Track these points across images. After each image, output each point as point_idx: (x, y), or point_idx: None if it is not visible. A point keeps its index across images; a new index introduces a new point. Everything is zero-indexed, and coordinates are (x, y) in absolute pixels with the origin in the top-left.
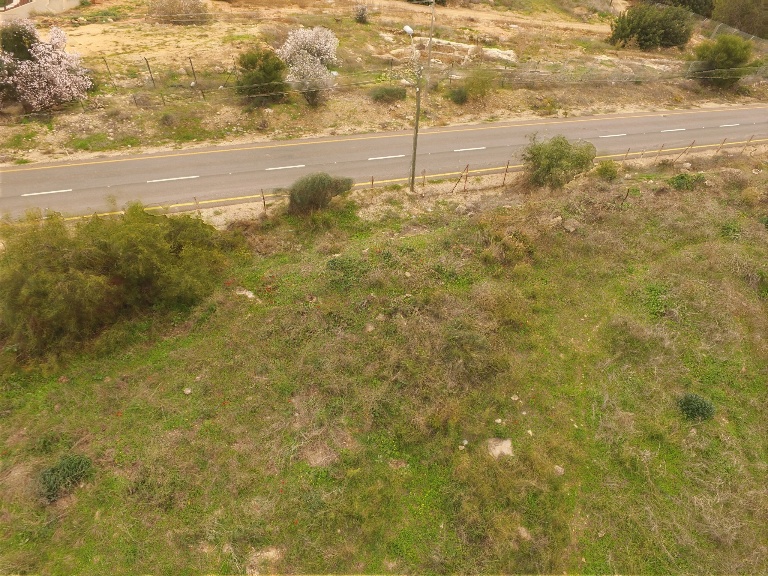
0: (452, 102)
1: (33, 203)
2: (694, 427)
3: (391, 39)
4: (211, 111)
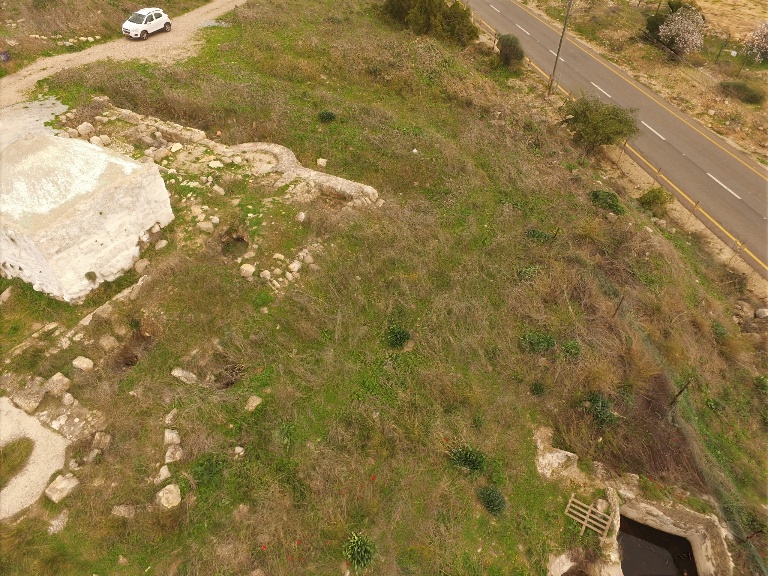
0: None
1: (485, 7)
2: None
3: None
4: None
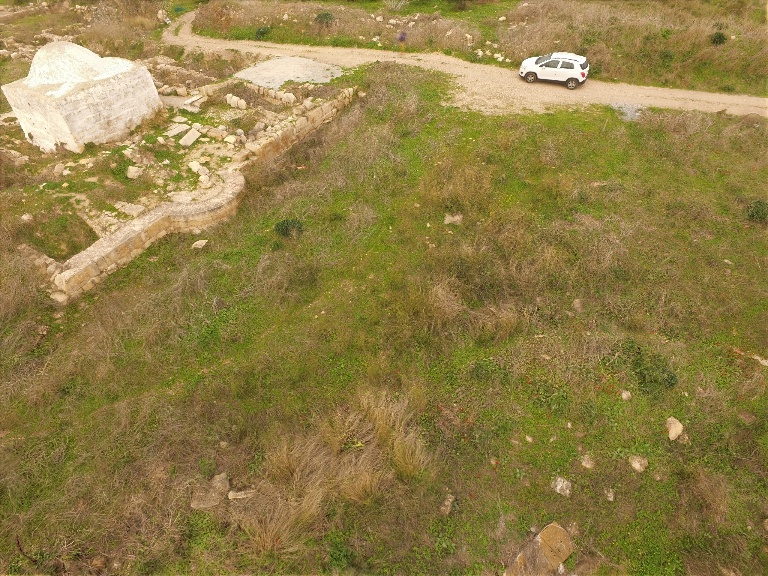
0: None
1: None
2: None
3: None
4: None
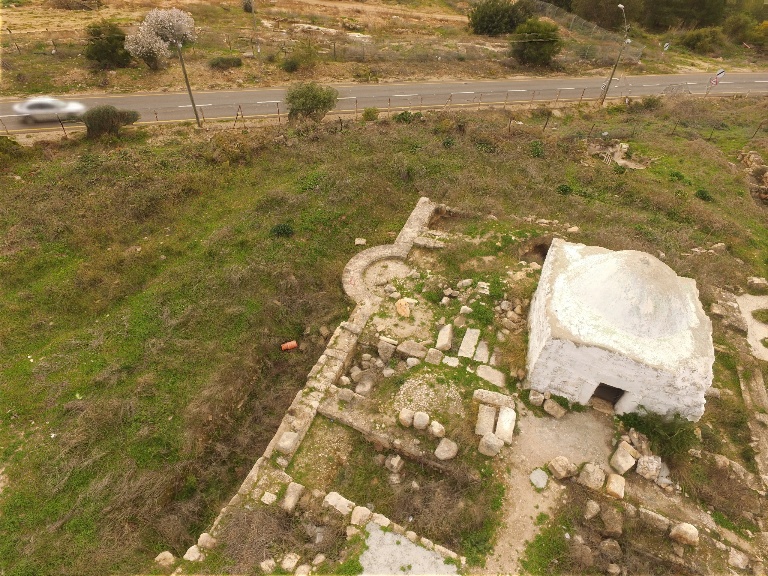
0: (283, 70)
1: None
2: (273, 240)
3: (269, 25)
4: (62, 72)
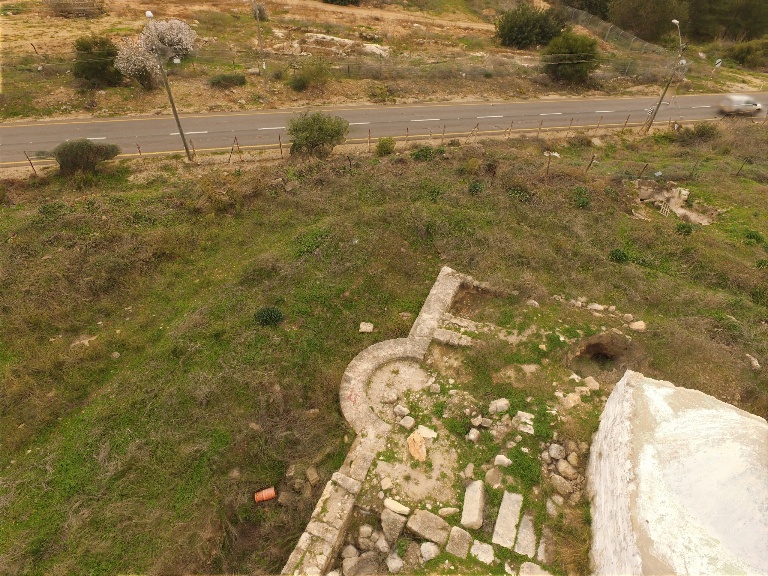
0: (291, 89)
1: None
2: (256, 330)
3: (280, 35)
4: (46, 92)
